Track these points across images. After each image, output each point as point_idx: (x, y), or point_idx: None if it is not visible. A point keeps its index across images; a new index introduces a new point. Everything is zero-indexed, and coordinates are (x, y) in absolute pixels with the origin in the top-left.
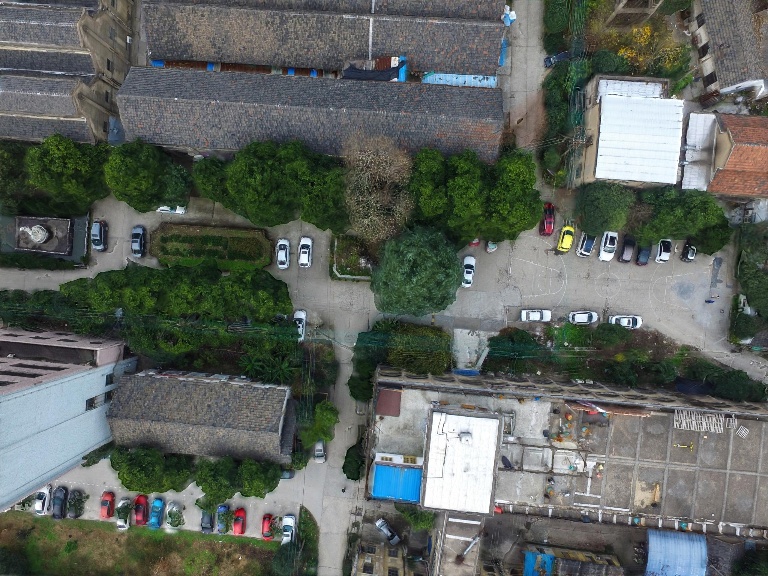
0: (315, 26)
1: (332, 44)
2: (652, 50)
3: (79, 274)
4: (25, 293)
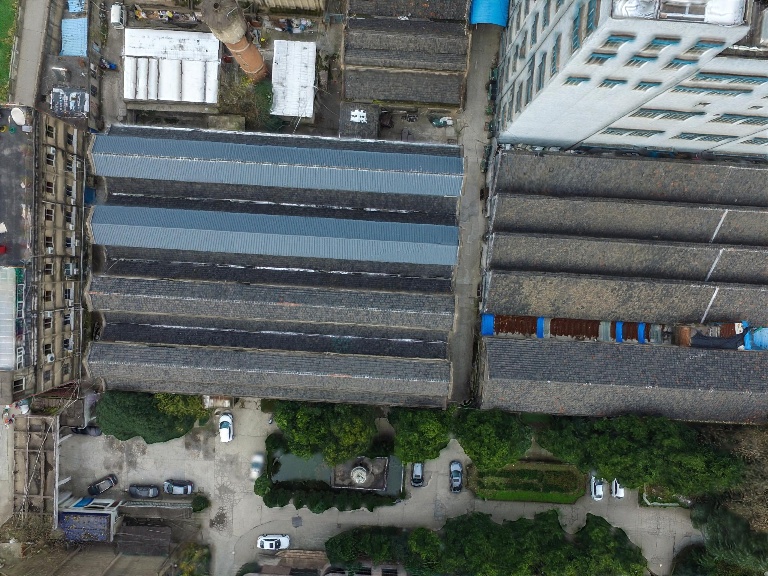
0: (660, 292)
1: (671, 305)
2: None
3: (394, 507)
4: (353, 536)
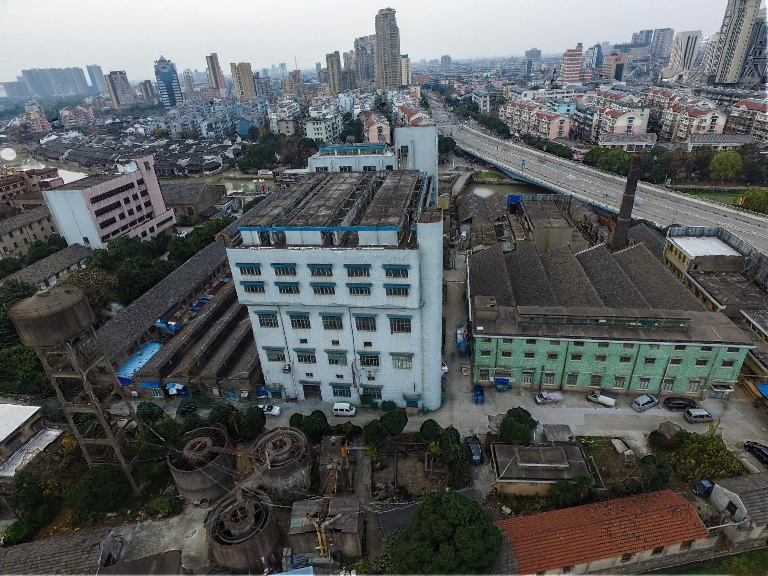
0: None
1: None
2: (50, 455)
3: None
4: (167, 243)
